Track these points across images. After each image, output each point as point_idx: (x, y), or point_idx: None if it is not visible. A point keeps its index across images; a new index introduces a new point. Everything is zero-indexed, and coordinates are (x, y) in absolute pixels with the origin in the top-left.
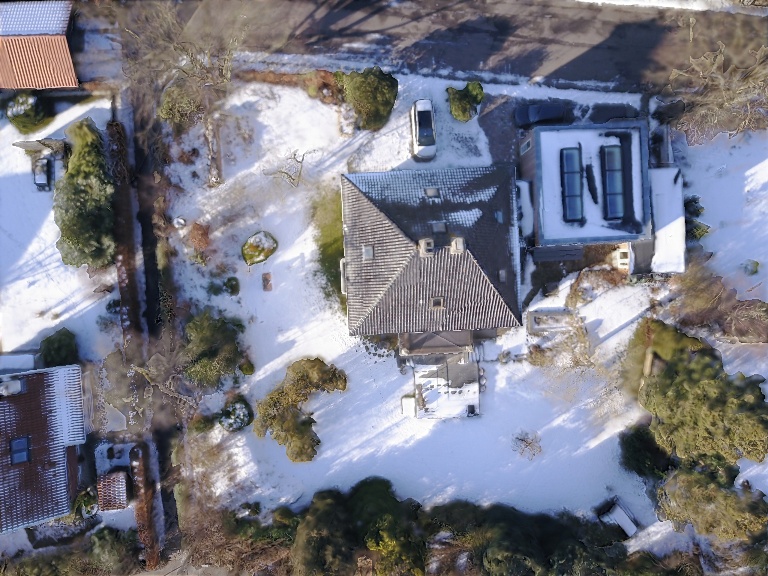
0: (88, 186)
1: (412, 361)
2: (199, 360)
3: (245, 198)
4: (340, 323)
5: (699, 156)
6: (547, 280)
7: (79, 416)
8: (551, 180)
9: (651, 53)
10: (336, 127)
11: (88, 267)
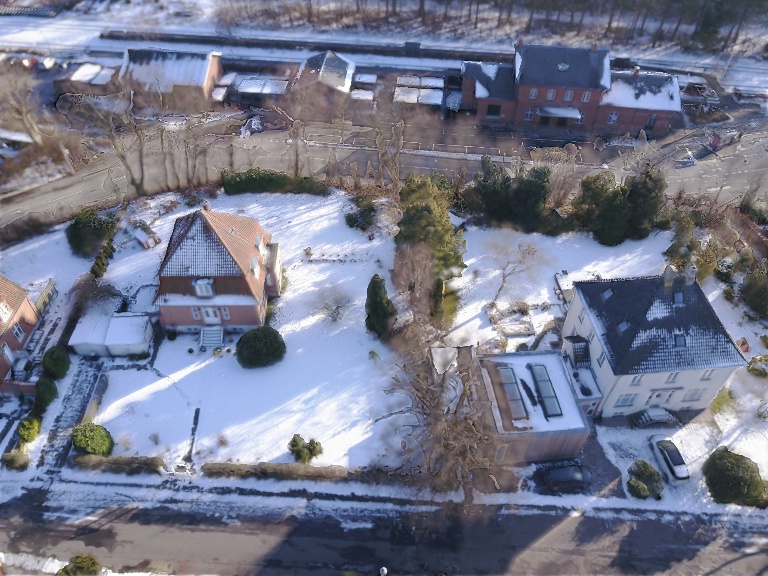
0: None
1: None
2: None
3: None
4: None
5: None
6: None
7: None
8: (563, 394)
9: (470, 544)
10: None
11: None
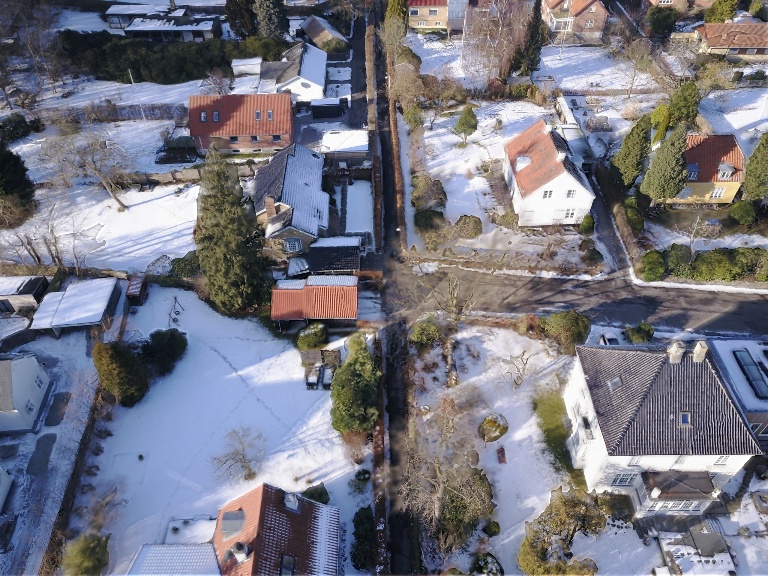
0: (362, 371)
1: (654, 529)
2: (472, 477)
3: (477, 395)
4: None
5: None
6: None
7: (334, 556)
8: (734, 371)
9: (767, 318)
10: (543, 352)
11: (350, 434)
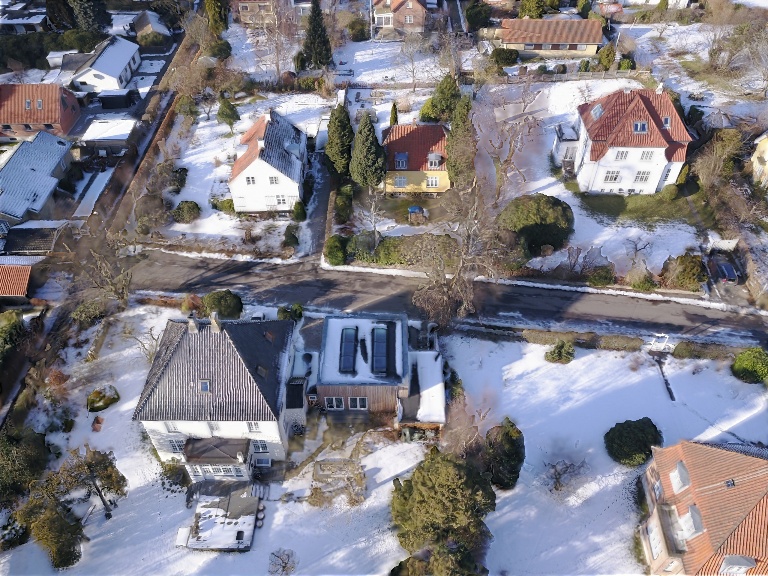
0: None
1: (199, 493)
2: (0, 439)
3: (109, 369)
4: (147, 461)
5: (466, 358)
6: (336, 436)
7: None
8: (333, 347)
9: None
10: None
11: None
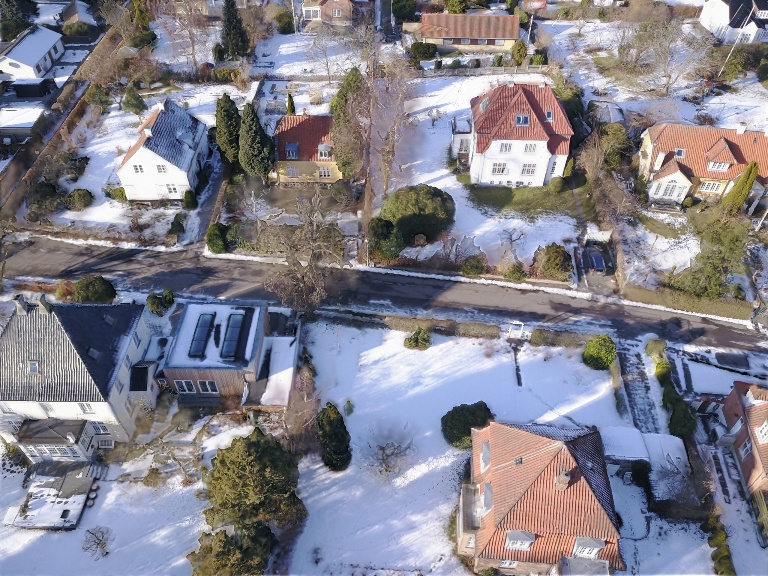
0: None
1: (36, 473)
2: None
3: None
4: None
5: (328, 345)
6: (184, 419)
7: None
8: (188, 332)
9: None
10: None
11: None
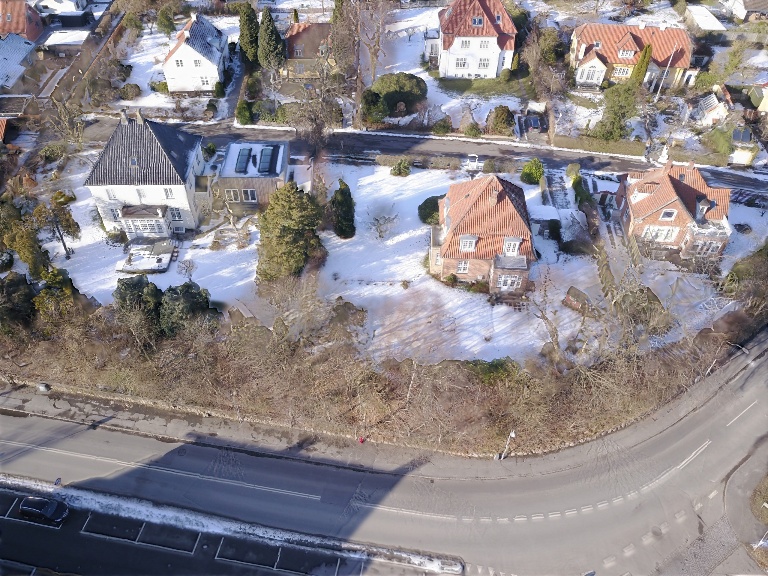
0: None
1: (132, 244)
2: None
3: (68, 184)
4: (96, 231)
5: None
6: None
7: None
8: (232, 159)
9: None
10: None
11: None
